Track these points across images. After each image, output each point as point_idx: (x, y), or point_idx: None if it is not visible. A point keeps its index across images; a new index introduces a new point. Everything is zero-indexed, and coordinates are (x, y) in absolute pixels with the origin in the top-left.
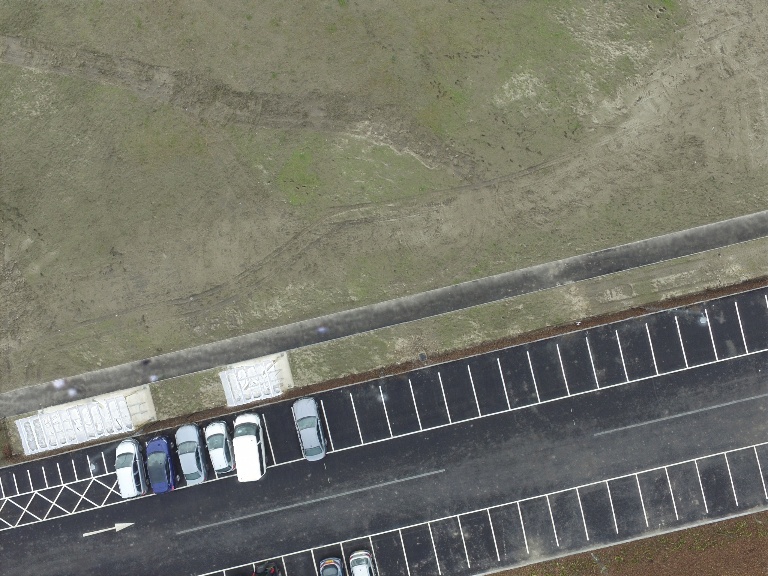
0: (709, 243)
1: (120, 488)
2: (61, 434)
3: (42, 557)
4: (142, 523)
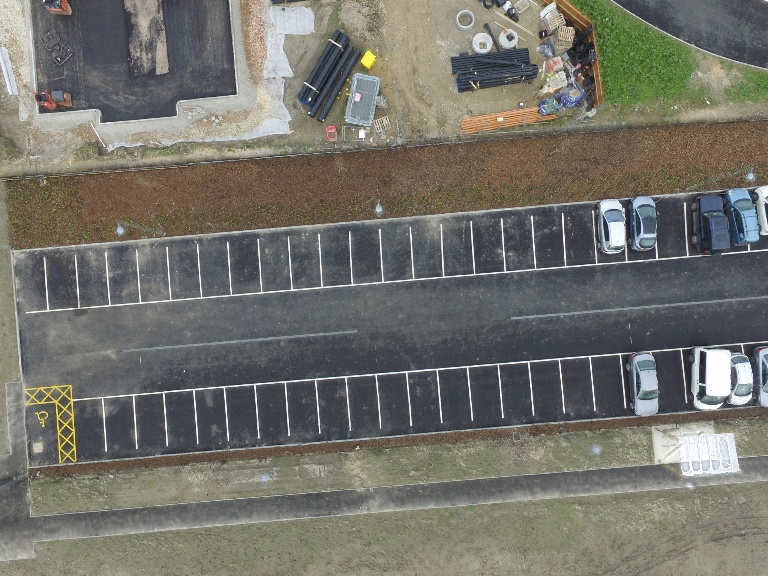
0: (216, 508)
1: None
2: None
3: None
4: None
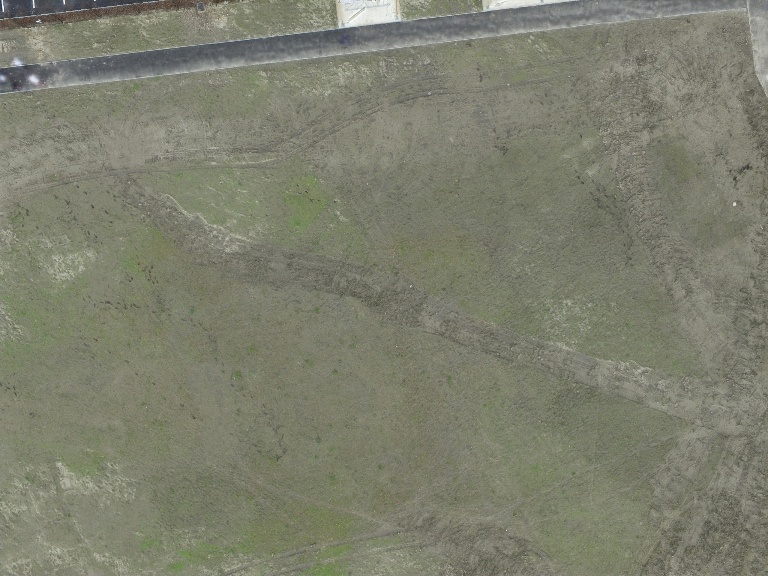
0: None
1: None
2: None
3: None
4: None
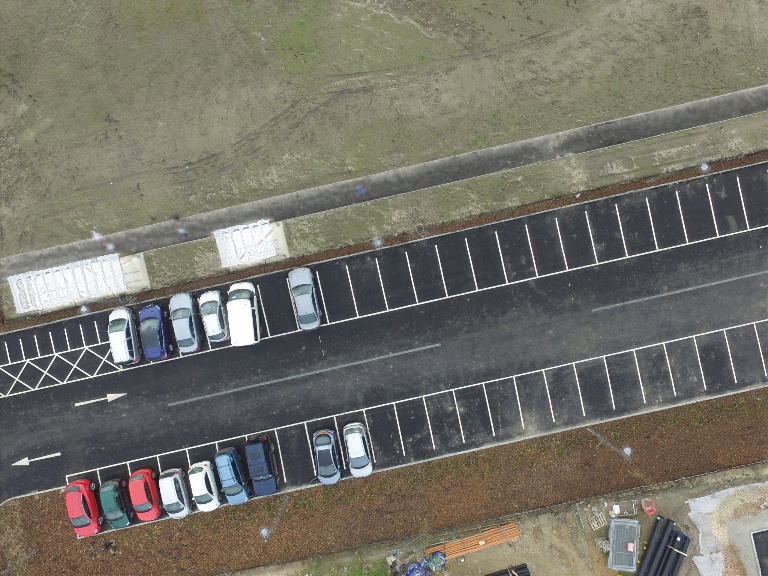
0: (711, 116)
1: (112, 352)
2: (54, 302)
3: (33, 427)
4: (134, 394)
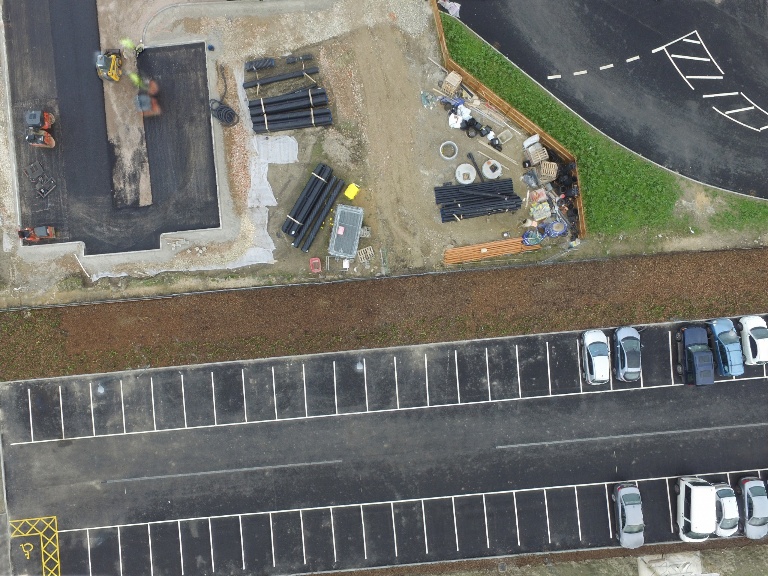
0: None
1: None
2: None
3: None
4: None
